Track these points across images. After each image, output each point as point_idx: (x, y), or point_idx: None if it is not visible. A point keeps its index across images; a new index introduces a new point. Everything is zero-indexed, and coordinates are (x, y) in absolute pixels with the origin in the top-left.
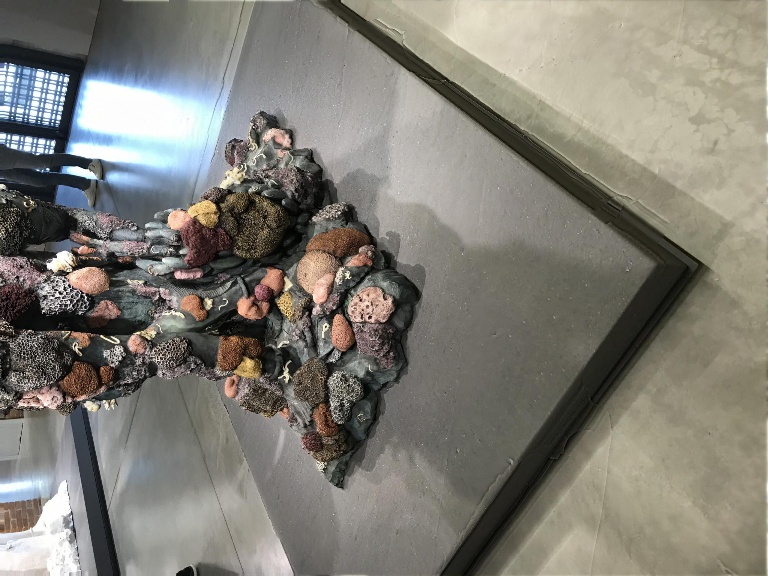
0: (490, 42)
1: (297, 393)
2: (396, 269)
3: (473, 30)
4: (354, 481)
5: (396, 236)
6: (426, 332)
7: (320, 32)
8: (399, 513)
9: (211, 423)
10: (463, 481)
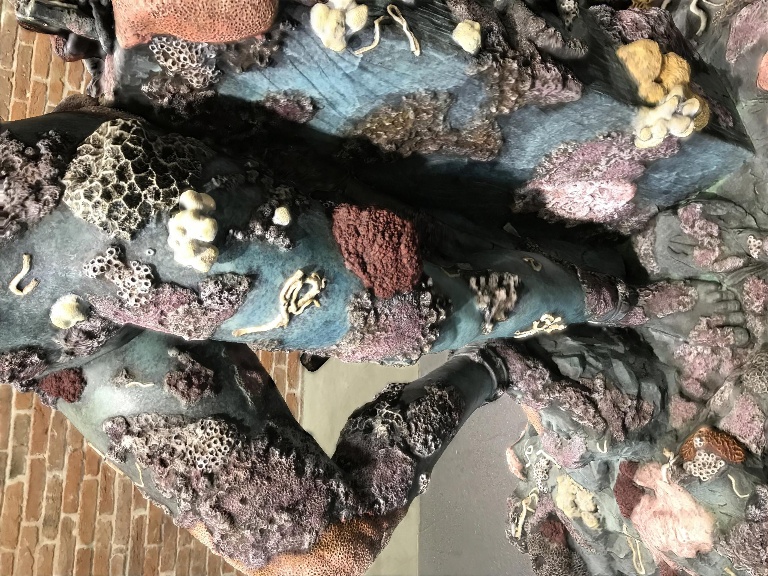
0: None
1: None
2: None
3: None
4: None
5: None
6: None
7: None
8: None
9: None
10: None
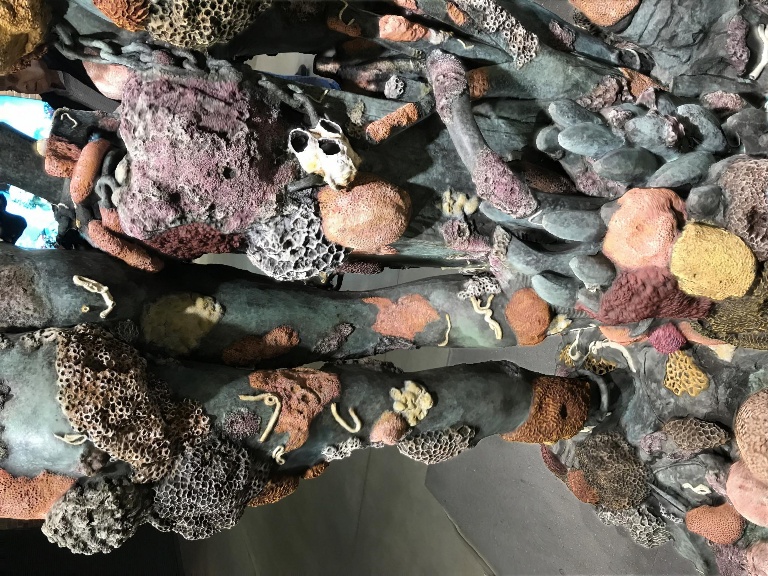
0: None
1: (580, 459)
2: None
3: None
4: None
5: None
6: None
7: None
8: (579, 574)
9: None
10: None
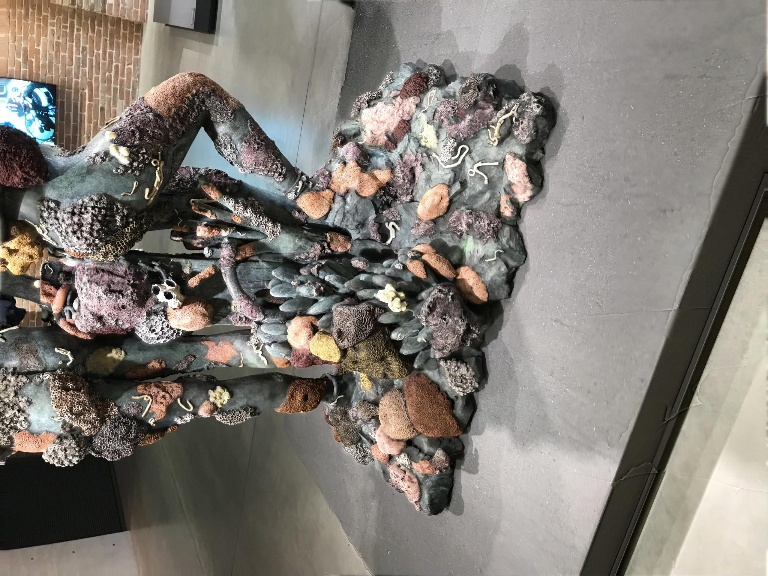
0: (703, 555)
1: None
2: (455, 470)
3: (715, 530)
4: None
5: (476, 467)
6: None
7: (671, 215)
8: (351, 482)
9: (328, 80)
10: (379, 558)
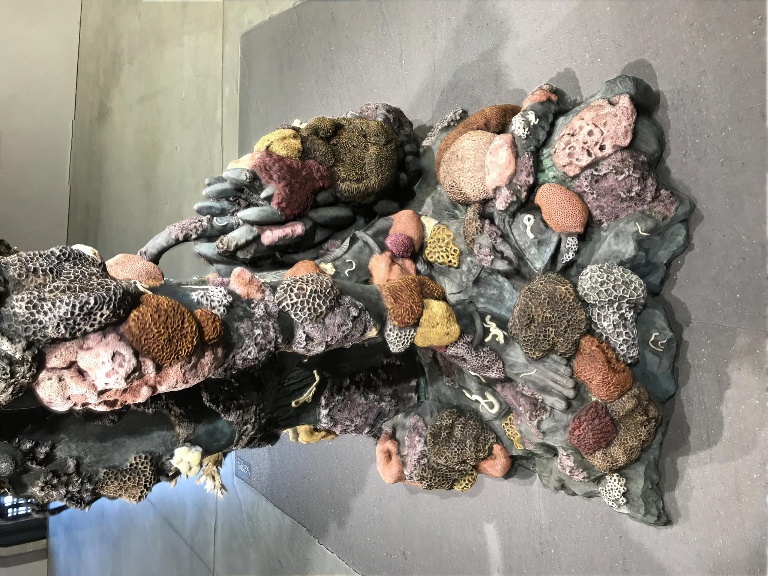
0: None
1: (531, 343)
2: None
3: None
4: (690, 489)
5: (563, 74)
6: (702, 129)
7: (334, 12)
8: None
9: None
10: None
